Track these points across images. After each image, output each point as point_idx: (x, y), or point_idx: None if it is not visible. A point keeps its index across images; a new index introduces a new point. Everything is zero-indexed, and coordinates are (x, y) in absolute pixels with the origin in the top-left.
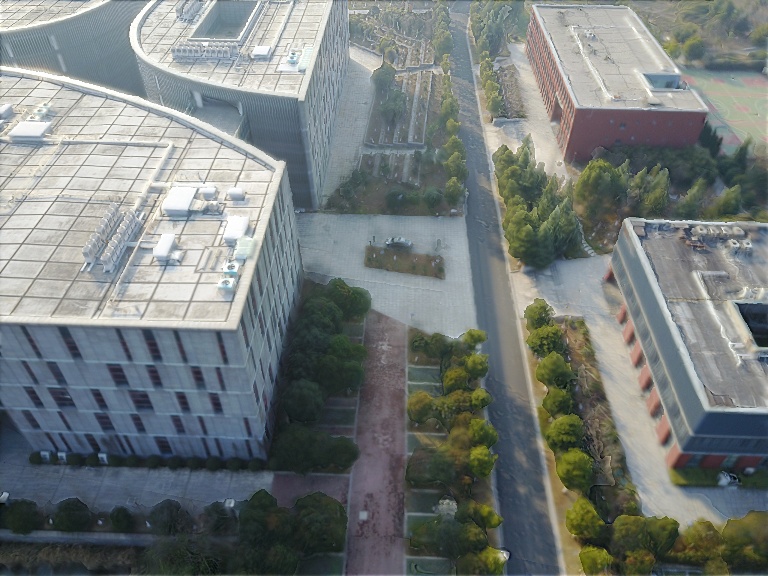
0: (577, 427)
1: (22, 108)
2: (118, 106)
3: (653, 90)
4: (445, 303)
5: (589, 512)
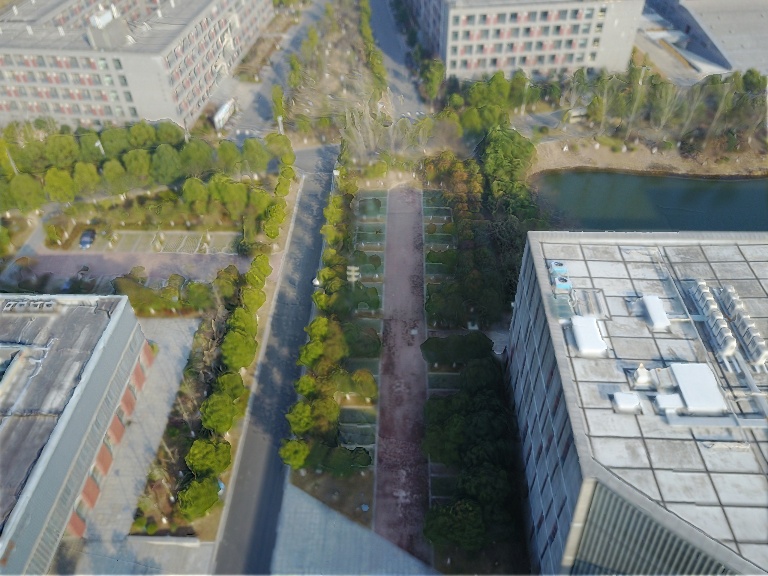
0: None
1: None
2: None
3: None
4: (315, 574)
5: None
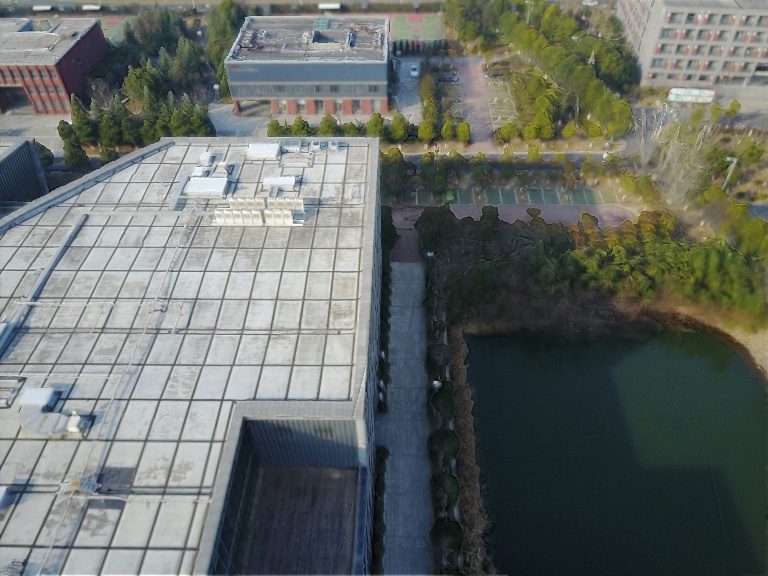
0: (380, 115)
1: None
2: None
3: (50, 32)
4: None
5: (428, 122)
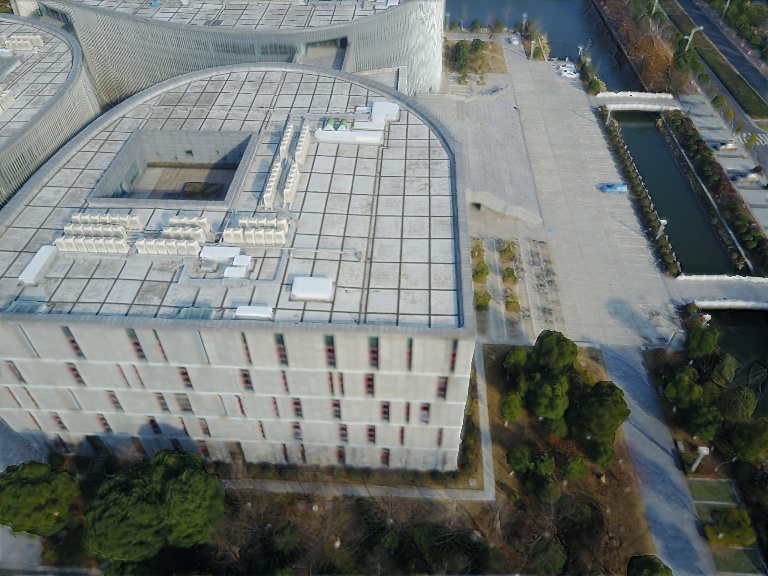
0: None
1: (174, 1)
2: (102, 6)
3: None
4: None
5: None
